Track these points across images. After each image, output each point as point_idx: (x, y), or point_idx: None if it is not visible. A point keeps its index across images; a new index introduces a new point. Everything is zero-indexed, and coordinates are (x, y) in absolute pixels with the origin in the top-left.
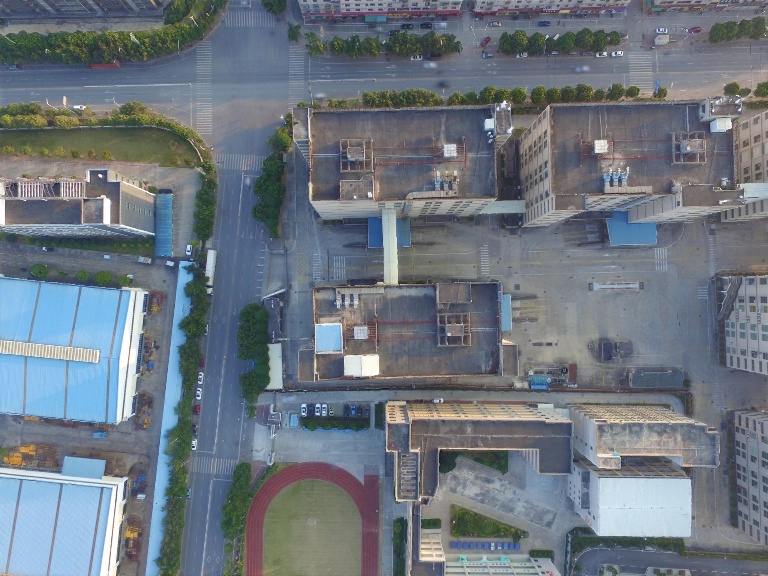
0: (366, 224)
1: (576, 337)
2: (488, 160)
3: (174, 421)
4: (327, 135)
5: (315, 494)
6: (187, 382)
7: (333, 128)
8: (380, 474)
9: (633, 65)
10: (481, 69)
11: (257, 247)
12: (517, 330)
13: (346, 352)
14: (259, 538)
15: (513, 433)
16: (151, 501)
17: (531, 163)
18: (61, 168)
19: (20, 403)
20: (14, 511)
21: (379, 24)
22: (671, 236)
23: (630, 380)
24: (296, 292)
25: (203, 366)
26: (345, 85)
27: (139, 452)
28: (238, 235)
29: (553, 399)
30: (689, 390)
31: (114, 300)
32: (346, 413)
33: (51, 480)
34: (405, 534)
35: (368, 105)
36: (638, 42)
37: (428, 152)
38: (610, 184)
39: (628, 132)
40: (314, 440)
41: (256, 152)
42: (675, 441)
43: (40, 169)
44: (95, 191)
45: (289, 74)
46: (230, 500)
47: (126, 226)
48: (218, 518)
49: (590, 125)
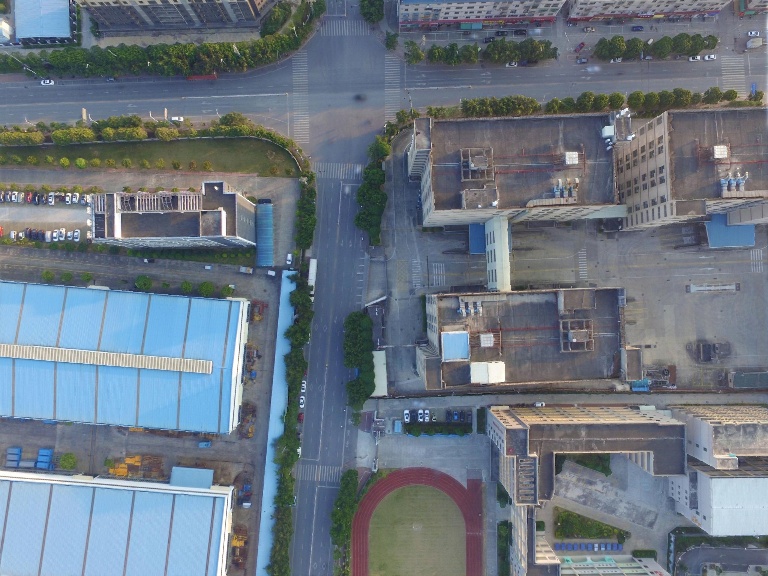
0: (467, 231)
1: (674, 339)
2: (606, 167)
3: (280, 430)
4: (447, 144)
5: (419, 499)
6: (294, 391)
7: (452, 137)
8: (483, 478)
9: (726, 68)
10: (575, 74)
11: (356, 255)
12: None
13: (470, 359)
14: (364, 544)
15: (627, 436)
16: (256, 509)
17: (637, 168)
18: (160, 180)
19: (133, 415)
20: (128, 522)
21: (474, 31)
22: (766, 237)
23: (730, 381)
24: (396, 299)
25: (306, 374)
26: (441, 92)
27: (243, 461)
28: (337, 243)
29: (653, 401)
30: None
31: (224, 311)
32: (449, 418)
33: (163, 491)
34: (510, 537)
35: (468, 112)
36: (730, 45)
37: (547, 160)
38: (727, 189)
39: (744, 137)
40: (417, 446)
41: (354, 161)
42: None
43: (139, 181)
44: (210, 203)
45: (385, 82)
46: (339, 507)
47: (240, 237)
48: (323, 525)
49: (706, 130)
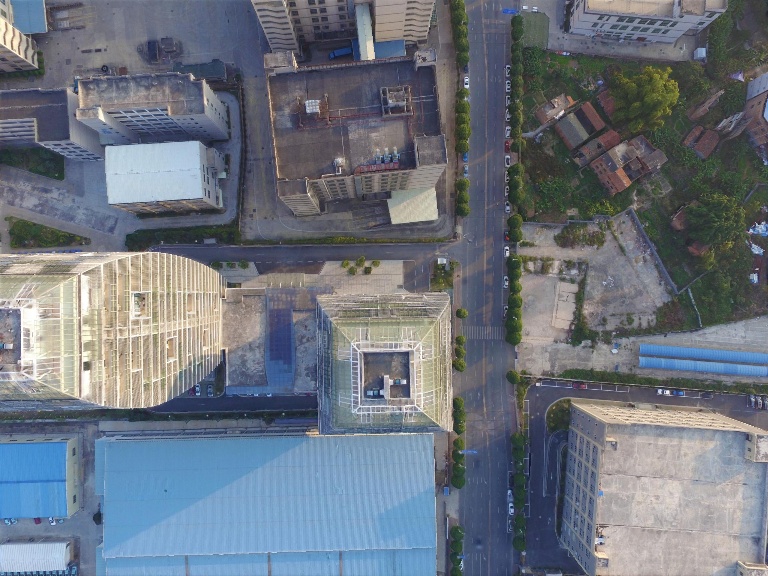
0: None
1: (125, 41)
2: None
3: None
4: None
5: None
6: None
7: None
8: None
9: None
10: None
11: None
12: (65, 39)
13: None
14: None
15: (9, 105)
16: None
17: None
18: None
19: None
20: None
21: None
22: None
23: None
24: None
25: None
26: None
27: None
28: None
29: None
30: (241, 85)
31: None
32: None
33: None
34: None
35: None
36: None
37: None
38: None
39: None
40: None
41: None
42: (163, 94)
43: None
44: None
45: None
46: None
47: None
48: None
49: None
